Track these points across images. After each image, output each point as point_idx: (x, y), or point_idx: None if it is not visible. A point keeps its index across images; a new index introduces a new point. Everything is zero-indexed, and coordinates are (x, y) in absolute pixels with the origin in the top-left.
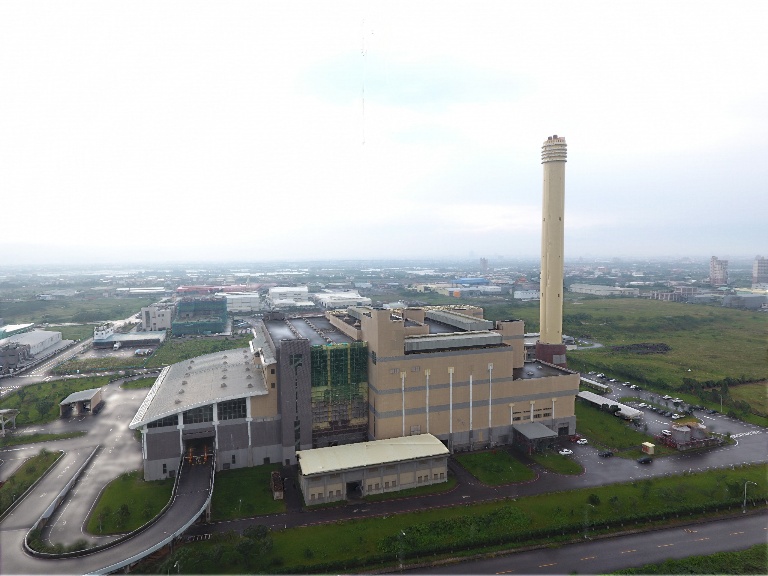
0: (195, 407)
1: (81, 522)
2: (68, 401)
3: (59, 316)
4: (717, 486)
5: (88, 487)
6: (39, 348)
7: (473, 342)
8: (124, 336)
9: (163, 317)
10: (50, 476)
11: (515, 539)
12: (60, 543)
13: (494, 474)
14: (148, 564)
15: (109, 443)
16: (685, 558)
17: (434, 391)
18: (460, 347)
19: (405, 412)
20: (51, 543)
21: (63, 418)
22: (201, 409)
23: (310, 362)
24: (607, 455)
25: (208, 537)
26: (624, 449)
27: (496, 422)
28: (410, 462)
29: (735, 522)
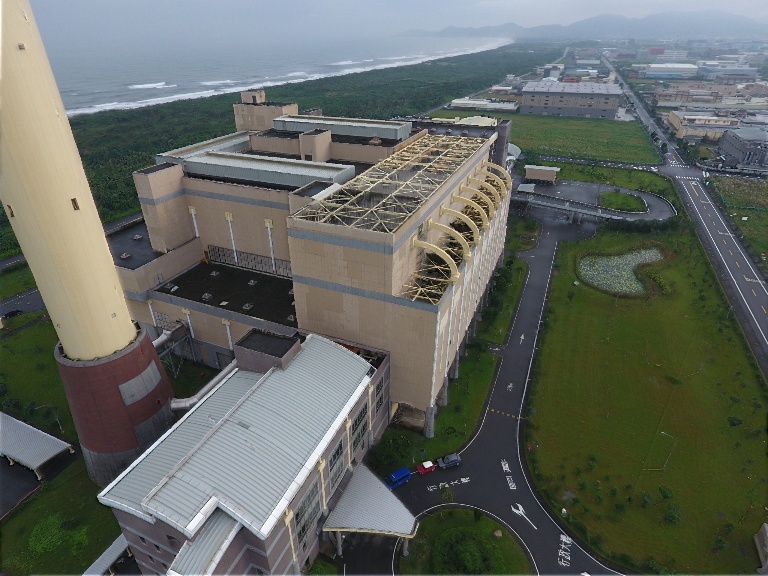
0: None
1: None
2: None
3: None
4: None
5: None
6: None
7: None
8: None
9: None
10: None
11: None
12: None
13: None
14: None
15: None
16: None
17: None
18: None
19: None
20: None
21: None
22: None
23: None
24: None
25: None
26: (29, 325)
27: None
28: None
29: None
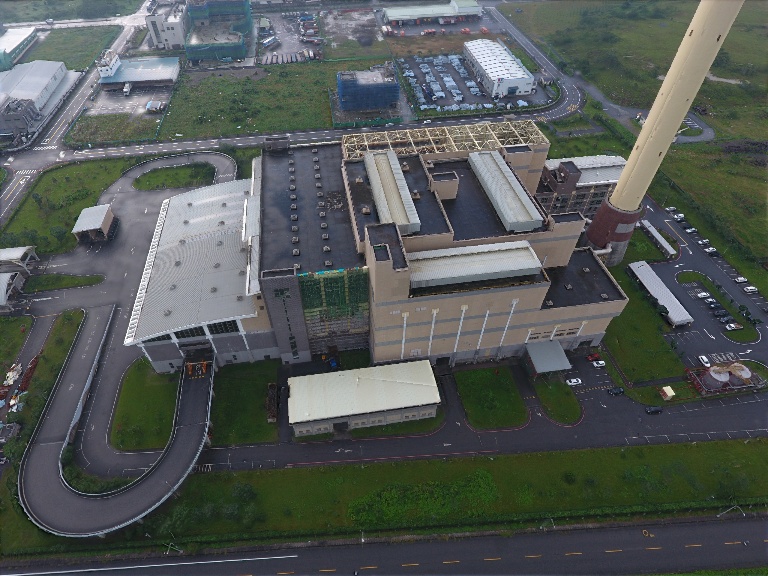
0: (183, 329)
1: (105, 430)
2: (79, 229)
3: (62, 1)
4: (710, 473)
5: (109, 375)
6: (44, 96)
7: (501, 275)
8: (132, 71)
9: (173, 31)
10: (75, 354)
11: (473, 524)
12: (90, 457)
13: (485, 412)
14: (154, 519)
15: (124, 300)
16: (624, 573)
17: (441, 324)
18: (482, 281)
19: (405, 341)
20: (84, 456)
21: (81, 245)
22: (191, 328)
23: (299, 294)
24: (617, 394)
25: (208, 469)
26: (641, 383)
27: (508, 341)
28: (397, 411)
29: (700, 529)
